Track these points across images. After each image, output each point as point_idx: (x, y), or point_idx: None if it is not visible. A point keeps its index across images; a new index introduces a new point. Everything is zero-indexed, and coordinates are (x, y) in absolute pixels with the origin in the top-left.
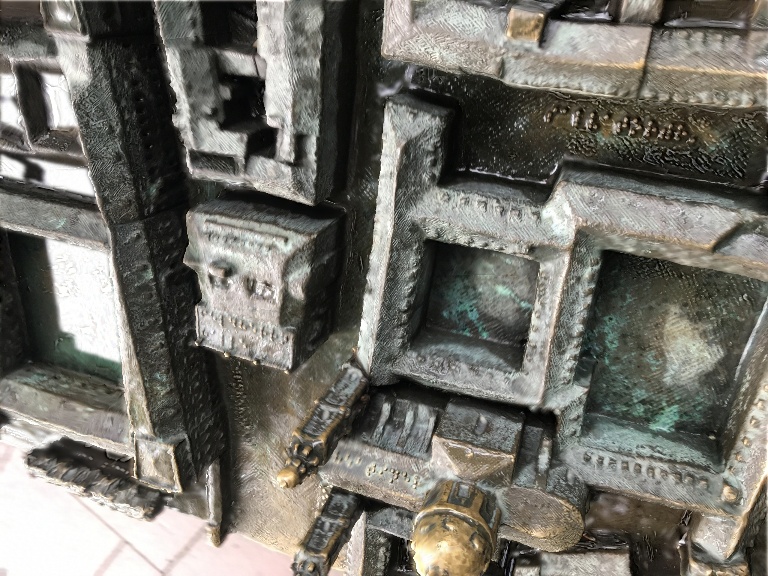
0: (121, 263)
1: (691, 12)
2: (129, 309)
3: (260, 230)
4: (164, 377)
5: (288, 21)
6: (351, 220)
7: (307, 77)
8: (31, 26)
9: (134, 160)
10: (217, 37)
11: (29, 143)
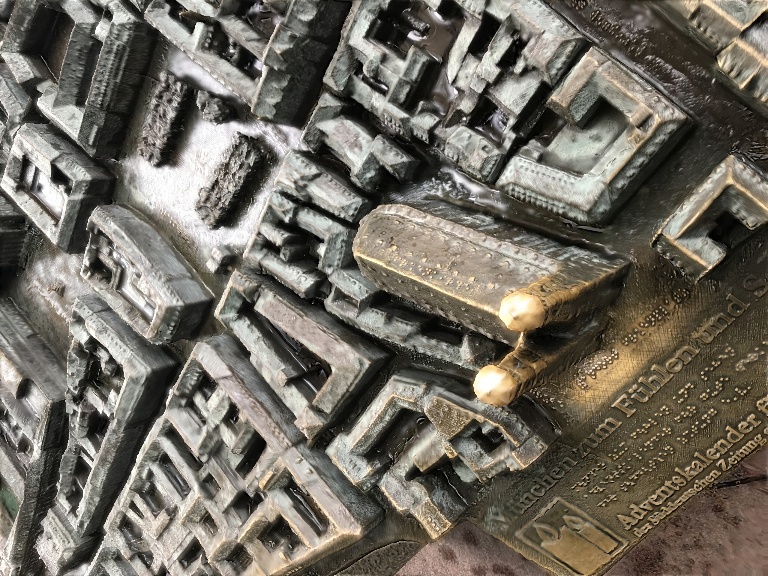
0: (23, 508)
1: None
2: (19, 521)
3: (64, 533)
4: (22, 545)
5: (89, 495)
6: (103, 538)
7: (90, 510)
8: (35, 421)
9: (44, 480)
10: (81, 470)
11: (17, 452)
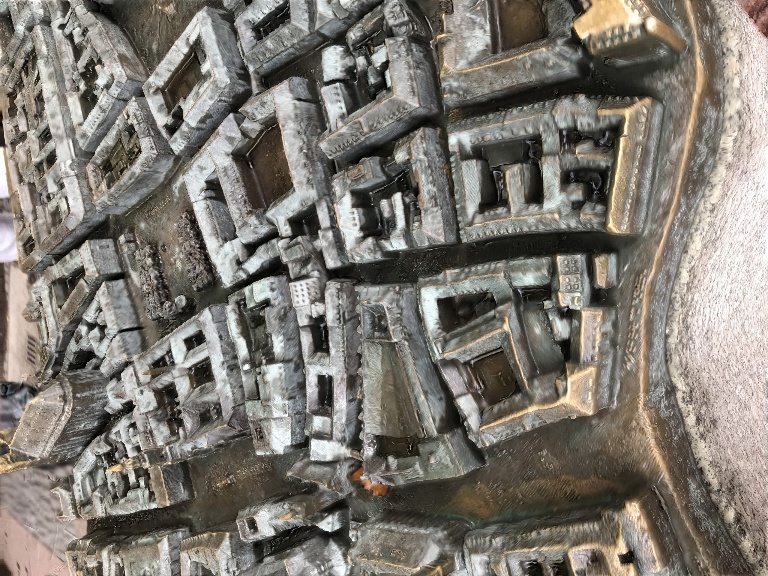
0: None
1: None
2: None
3: None
4: None
5: None
6: None
7: None
8: None
9: None
10: None
11: None
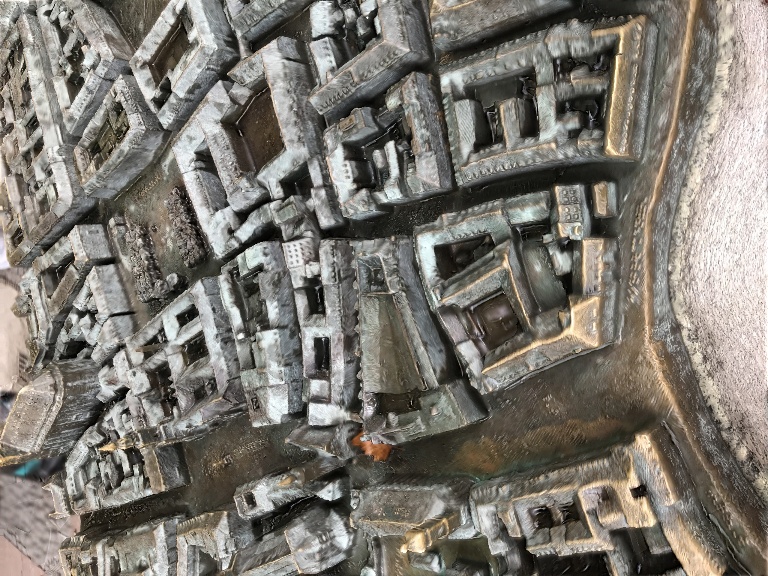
0: None
1: None
2: None
3: None
4: None
5: None
6: None
7: None
8: None
9: None
10: None
11: None
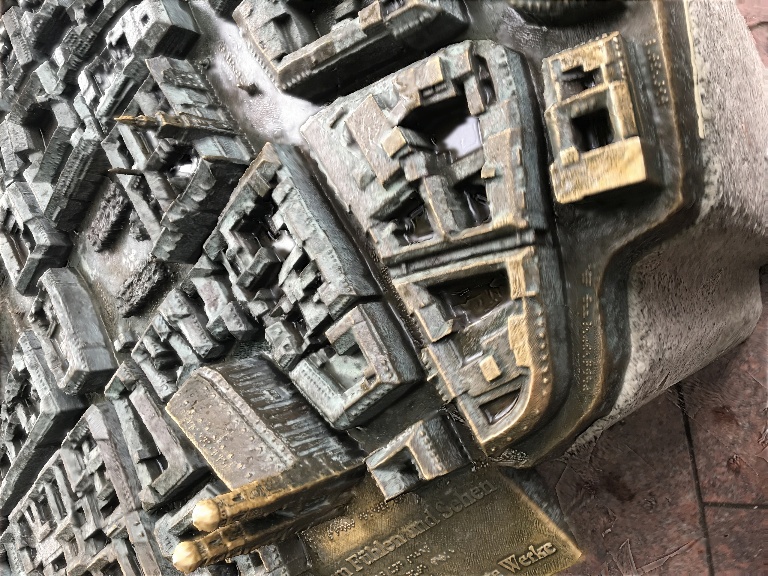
0: None
1: (41, 573)
2: None
3: None
4: None
5: (4, 488)
6: None
7: (3, 499)
8: None
9: None
10: (6, 463)
11: None
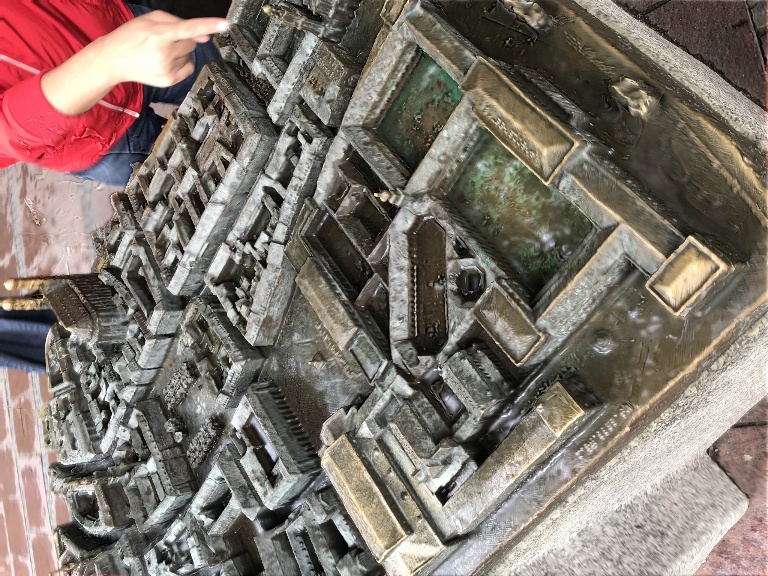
0: None
1: None
2: None
3: None
4: None
5: None
6: None
7: None
8: None
9: None
10: None
11: (352, 187)
